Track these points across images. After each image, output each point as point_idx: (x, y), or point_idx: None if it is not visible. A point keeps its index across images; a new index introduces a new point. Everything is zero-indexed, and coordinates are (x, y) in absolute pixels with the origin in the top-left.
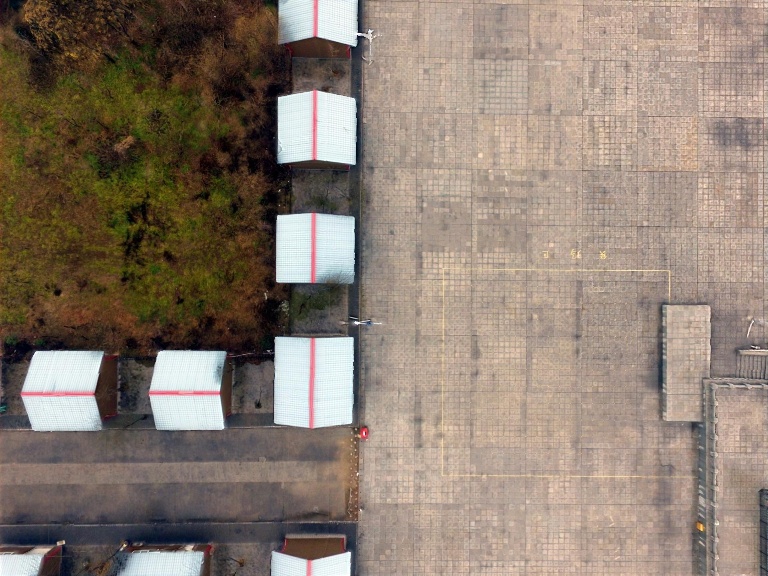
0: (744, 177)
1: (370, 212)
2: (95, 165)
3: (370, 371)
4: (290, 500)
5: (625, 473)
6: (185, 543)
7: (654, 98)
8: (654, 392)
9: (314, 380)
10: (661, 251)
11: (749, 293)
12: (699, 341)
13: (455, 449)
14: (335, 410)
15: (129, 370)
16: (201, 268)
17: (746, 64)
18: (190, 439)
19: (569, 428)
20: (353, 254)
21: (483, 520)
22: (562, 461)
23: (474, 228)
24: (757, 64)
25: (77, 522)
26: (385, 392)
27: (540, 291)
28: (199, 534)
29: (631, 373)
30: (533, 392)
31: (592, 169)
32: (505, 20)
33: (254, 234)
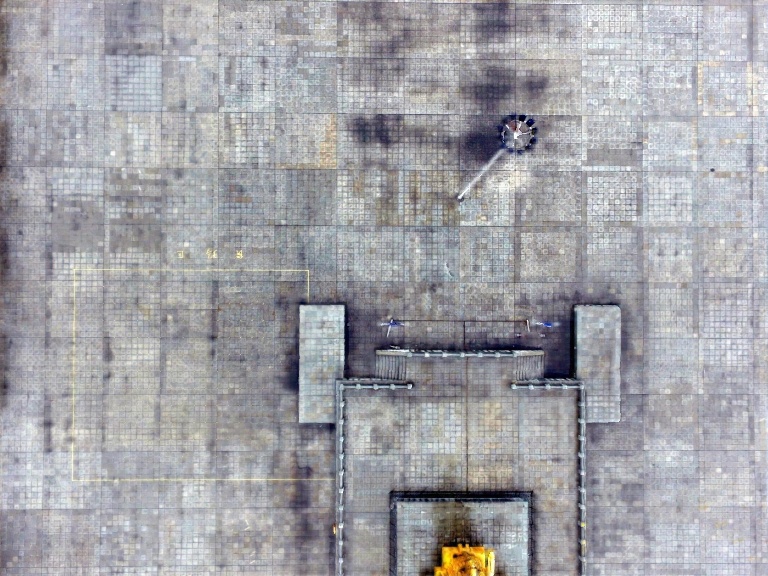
0: (384, 175)
1: None
2: None
3: None
4: None
5: (261, 476)
6: None
7: (292, 94)
8: (292, 393)
9: None
10: (299, 250)
11: (389, 292)
12: (332, 341)
13: (86, 454)
14: None
15: None
16: None
17: (386, 60)
18: None
19: (204, 431)
20: None
21: (115, 525)
22: (197, 465)
23: (106, 228)
24: (397, 60)
25: None
26: (13, 396)
27: (175, 292)
28: None
29: (268, 374)
30: (167, 395)
31: (228, 167)
32: (137, 15)
33: None
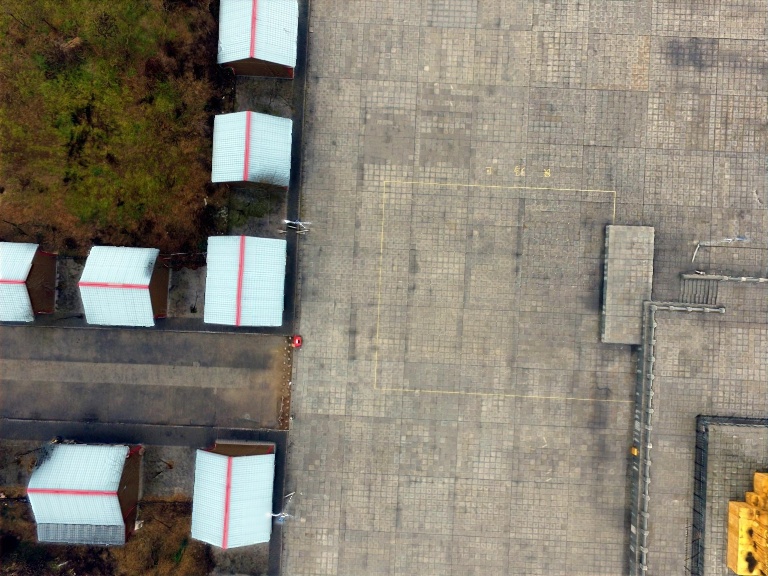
0: (696, 98)
1: (313, 122)
2: (42, 65)
3: (307, 281)
4: (222, 406)
5: (560, 394)
6: (116, 443)
7: (606, 15)
8: (594, 314)
9: (243, 278)
10: (607, 171)
11: (696, 217)
12: (641, 263)
13: (389, 363)
14: (264, 310)
15: (68, 269)
16: (142, 171)
17: None
18: (125, 341)
19: (505, 347)
20: (289, 157)
21: (414, 435)
22: (497, 379)
23: (417, 141)
24: None
25: (12, 417)
26: (321, 303)
27: (481, 207)
28: (130, 434)
29: (571, 294)
30: (470, 309)
31: (540, 86)
32: None
33: (197, 140)
